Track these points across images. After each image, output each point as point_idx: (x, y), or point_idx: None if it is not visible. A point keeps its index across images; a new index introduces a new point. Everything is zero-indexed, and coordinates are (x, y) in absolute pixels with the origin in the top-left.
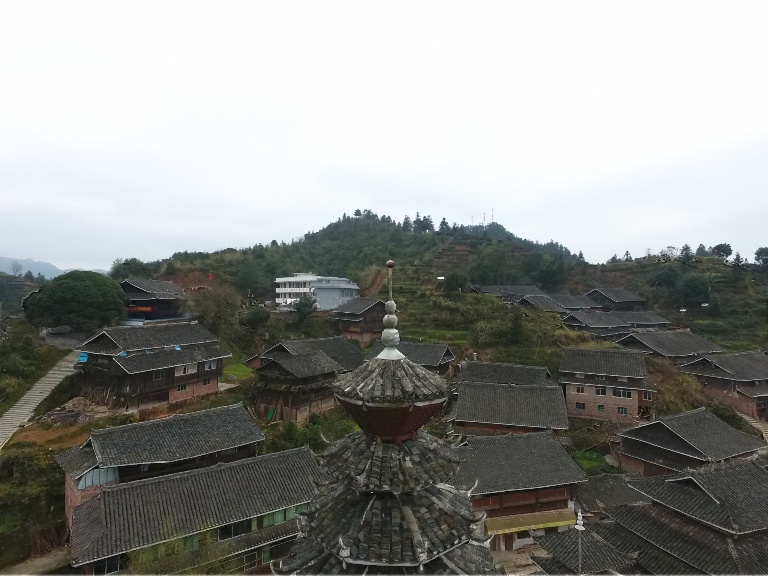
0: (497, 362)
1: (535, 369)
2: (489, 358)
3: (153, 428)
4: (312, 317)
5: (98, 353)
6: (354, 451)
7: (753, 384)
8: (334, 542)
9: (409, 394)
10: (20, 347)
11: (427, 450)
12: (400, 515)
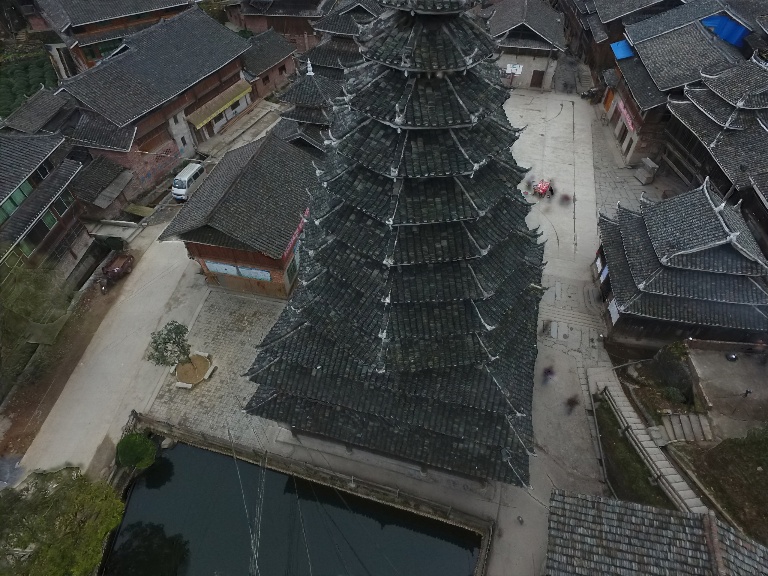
0: None
1: None
2: None
3: None
4: None
5: None
6: None
7: None
8: (453, 61)
9: None
10: None
11: None
12: (469, 27)
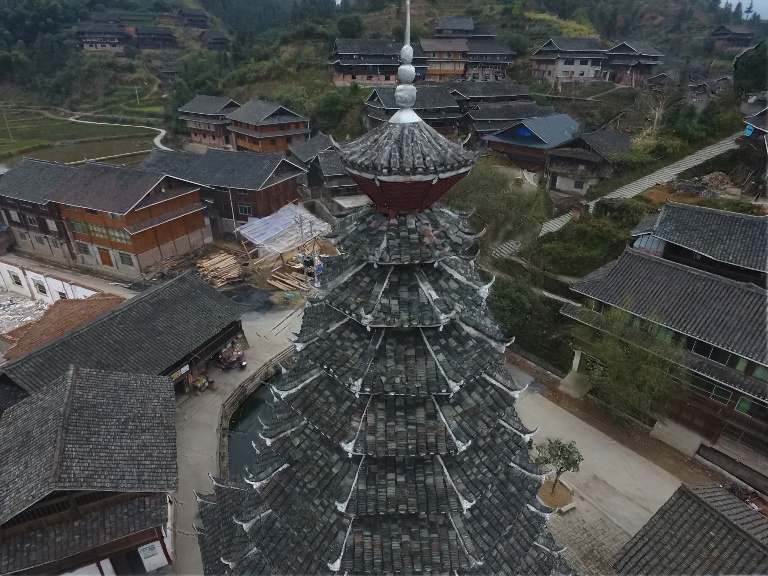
0: None
1: None
2: None
3: (729, 221)
4: None
5: (757, 127)
6: None
7: None
8: None
9: None
10: (702, 110)
11: None
12: None
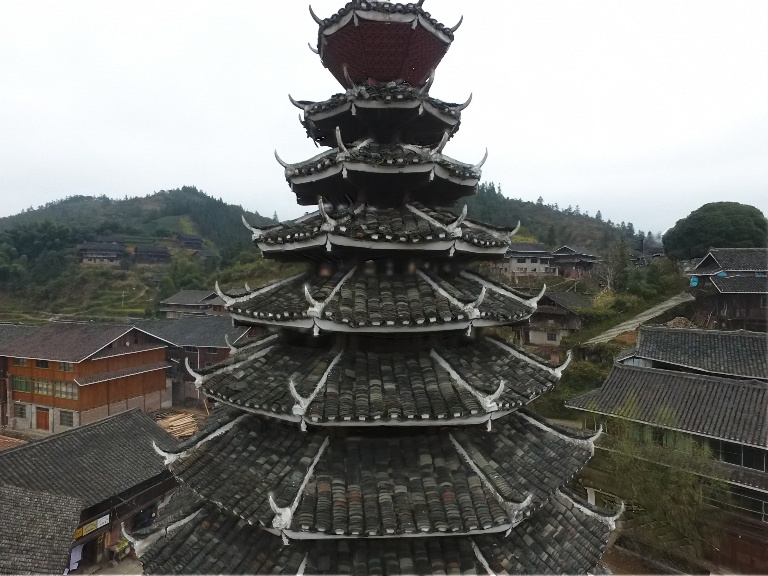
0: None
1: None
2: None
3: (707, 337)
4: None
5: (700, 274)
6: None
7: None
8: None
9: None
10: (647, 273)
11: None
12: None
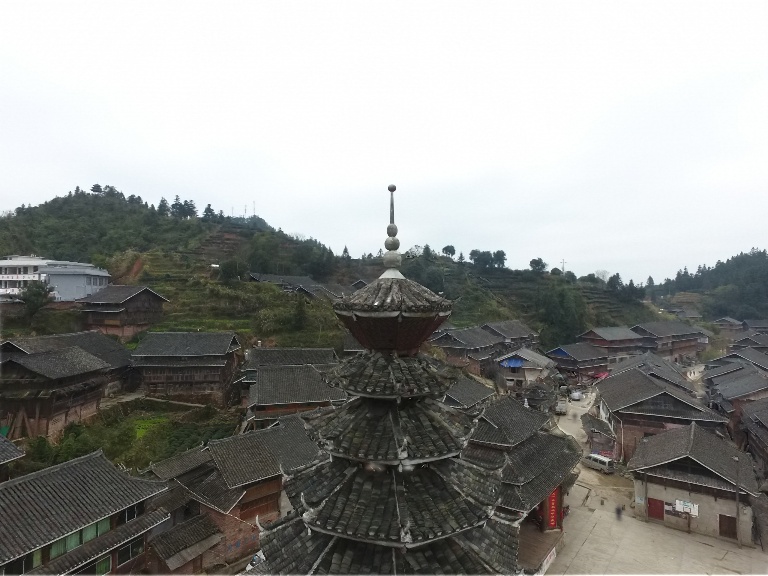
0: (286, 347)
1: (323, 350)
2: (274, 345)
3: None
4: (46, 310)
5: None
6: (375, 367)
7: (477, 351)
8: (383, 451)
9: (437, 303)
10: None
11: (434, 360)
12: (427, 418)
